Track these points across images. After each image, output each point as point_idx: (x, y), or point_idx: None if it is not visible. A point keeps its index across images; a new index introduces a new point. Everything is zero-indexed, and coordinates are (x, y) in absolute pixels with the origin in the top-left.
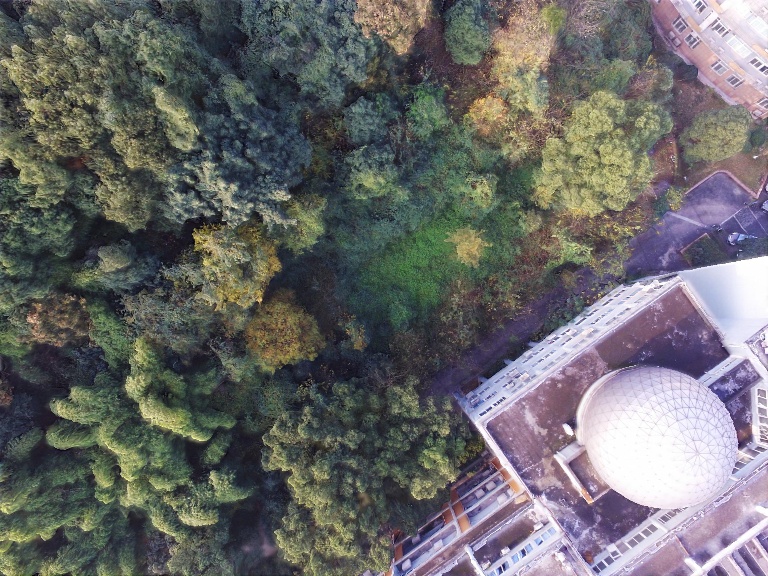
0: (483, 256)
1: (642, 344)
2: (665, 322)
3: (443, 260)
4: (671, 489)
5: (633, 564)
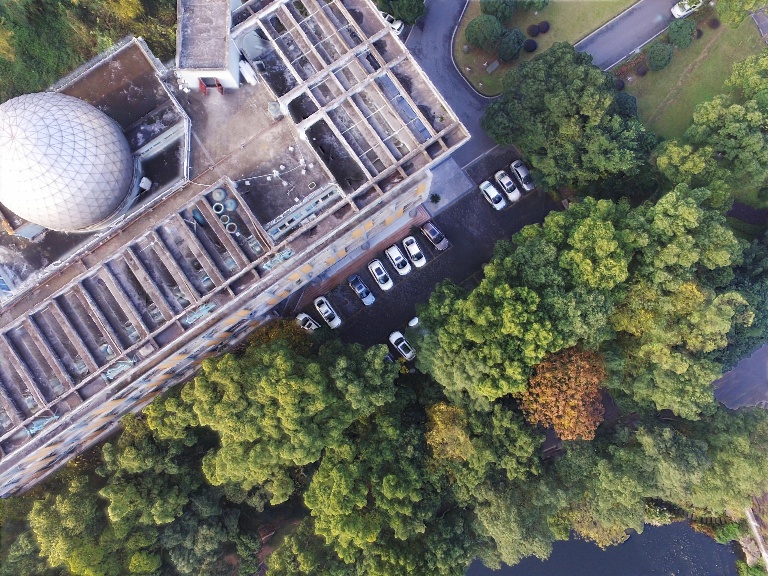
0: (50, 64)
1: (98, 99)
2: (122, 78)
3: (8, 67)
4: (2, 178)
5: (37, 286)
